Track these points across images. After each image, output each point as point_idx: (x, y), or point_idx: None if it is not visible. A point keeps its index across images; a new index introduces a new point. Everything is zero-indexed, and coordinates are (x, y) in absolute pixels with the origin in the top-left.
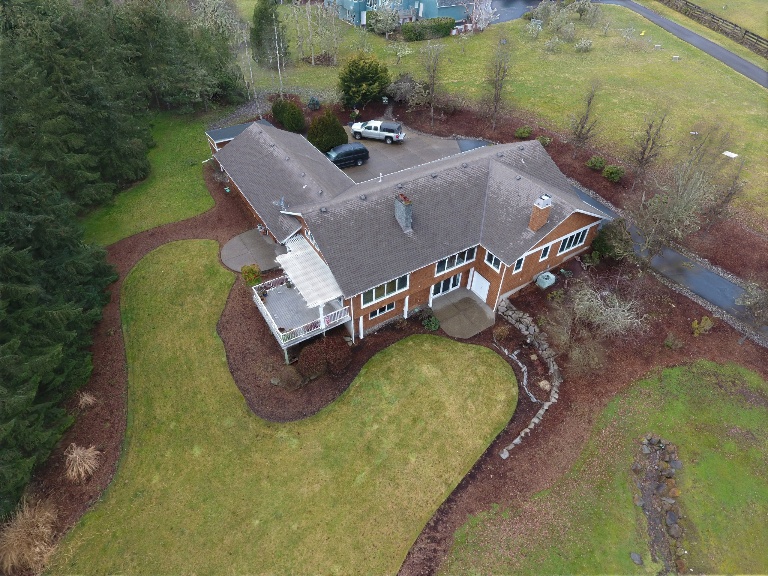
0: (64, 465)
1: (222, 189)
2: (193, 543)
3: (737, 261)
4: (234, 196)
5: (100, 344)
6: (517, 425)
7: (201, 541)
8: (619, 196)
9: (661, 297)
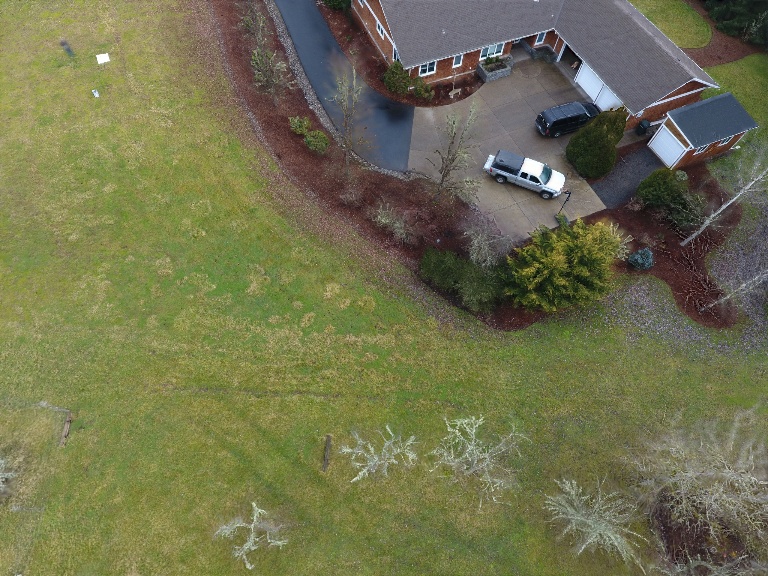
0: None
1: None
2: None
3: None
4: None
5: None
6: None
7: None
8: None
9: None
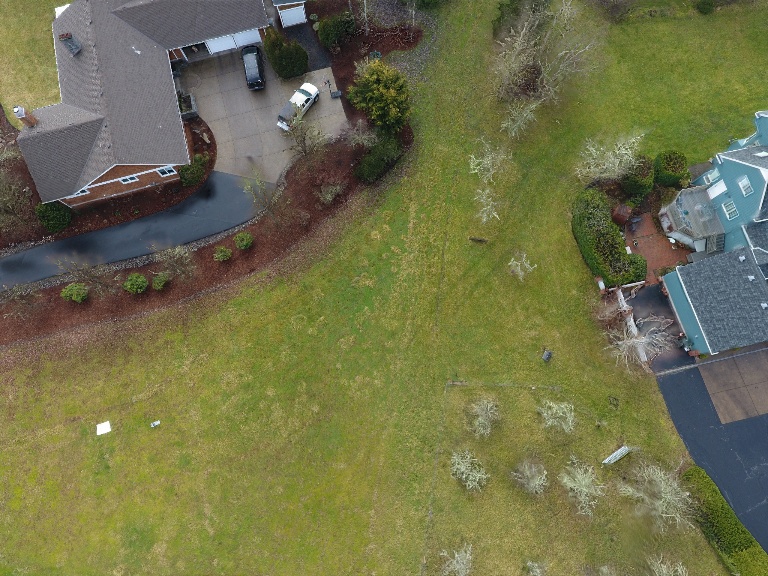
0: None
1: None
2: None
3: (7, 311)
4: None
5: None
6: (4, 121)
7: None
8: (119, 280)
9: (8, 226)
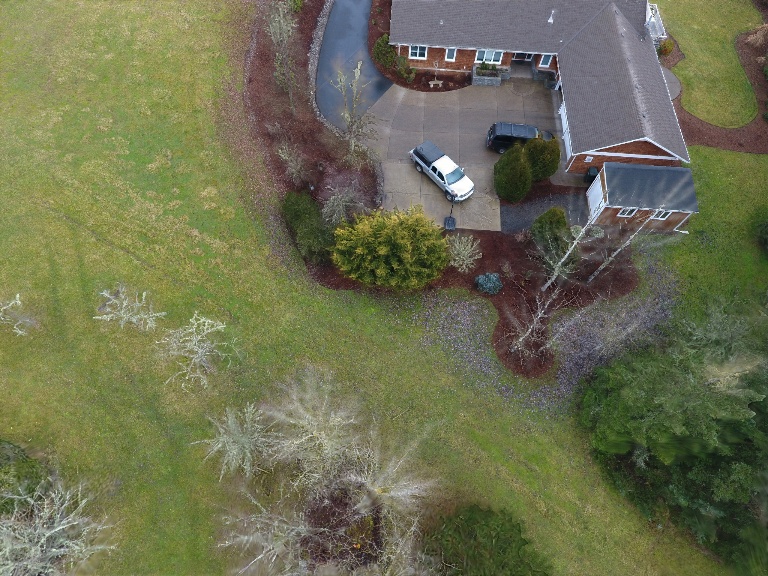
0: (764, 49)
1: None
2: (697, 6)
3: None
4: None
5: (763, 82)
6: None
7: (694, 5)
8: (311, 3)
9: None
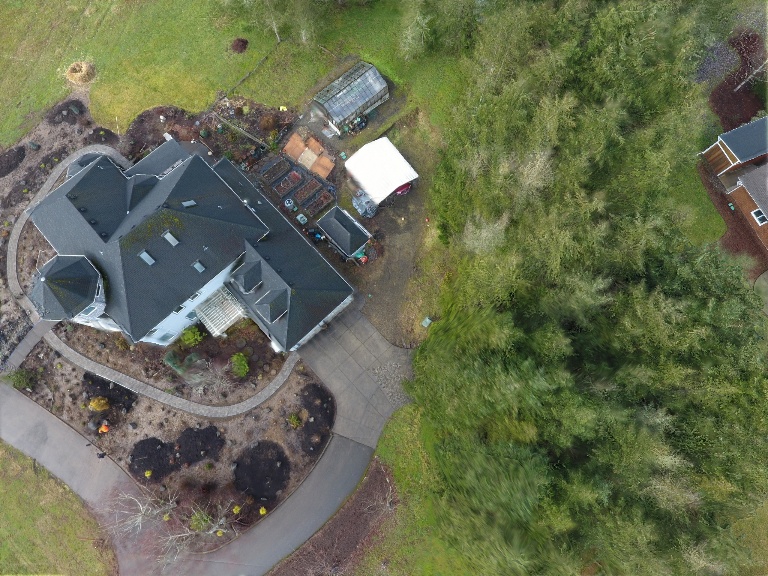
0: None
1: (726, 205)
2: None
3: None
4: (741, 217)
5: None
6: None
7: None
8: None
9: None
